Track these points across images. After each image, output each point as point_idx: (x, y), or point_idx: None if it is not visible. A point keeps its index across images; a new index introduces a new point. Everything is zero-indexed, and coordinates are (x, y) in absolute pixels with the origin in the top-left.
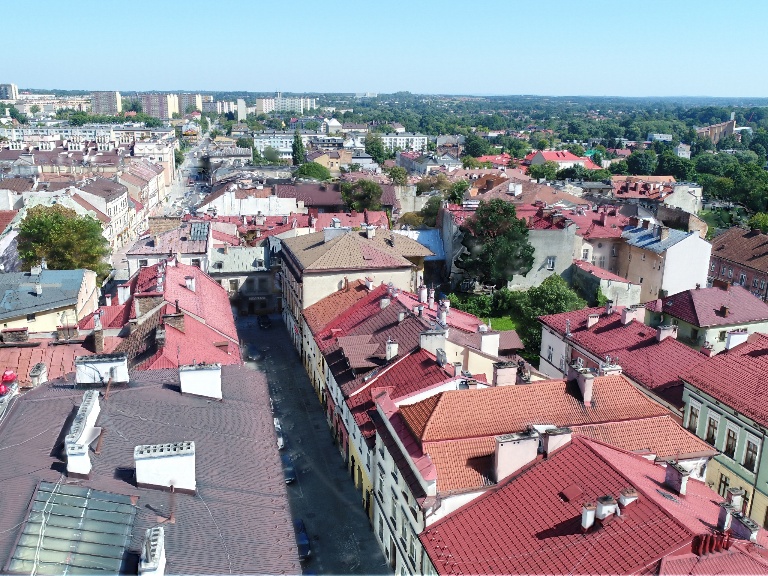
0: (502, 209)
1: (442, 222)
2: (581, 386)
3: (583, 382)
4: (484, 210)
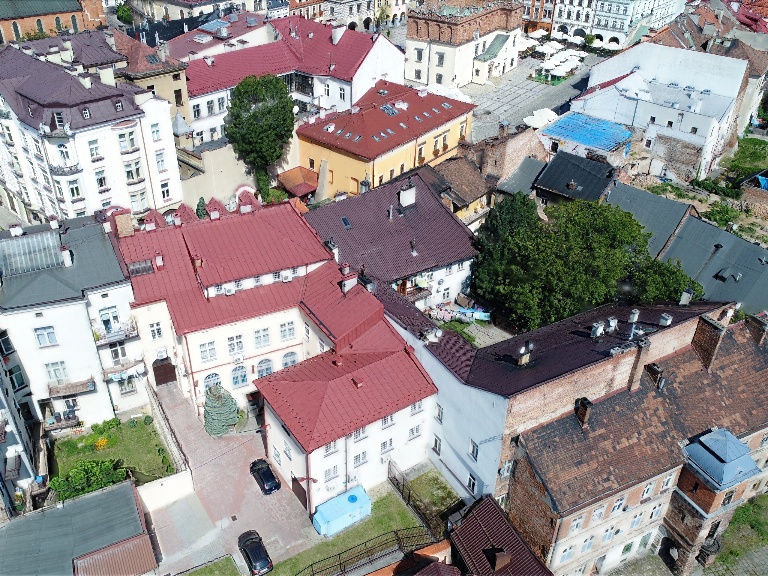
0: None
1: None
2: None
3: None
4: None
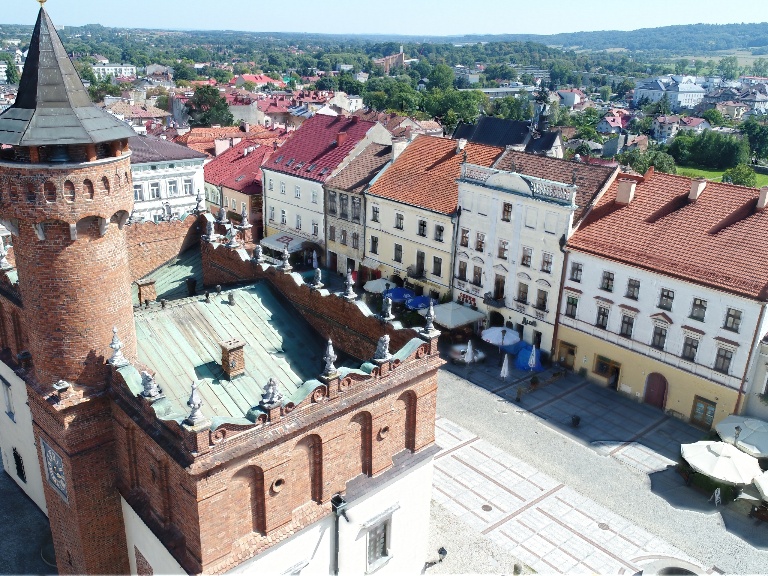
0: (211, 91)
1: (172, 106)
2: (245, 127)
3: (245, 125)
4: (200, 92)
